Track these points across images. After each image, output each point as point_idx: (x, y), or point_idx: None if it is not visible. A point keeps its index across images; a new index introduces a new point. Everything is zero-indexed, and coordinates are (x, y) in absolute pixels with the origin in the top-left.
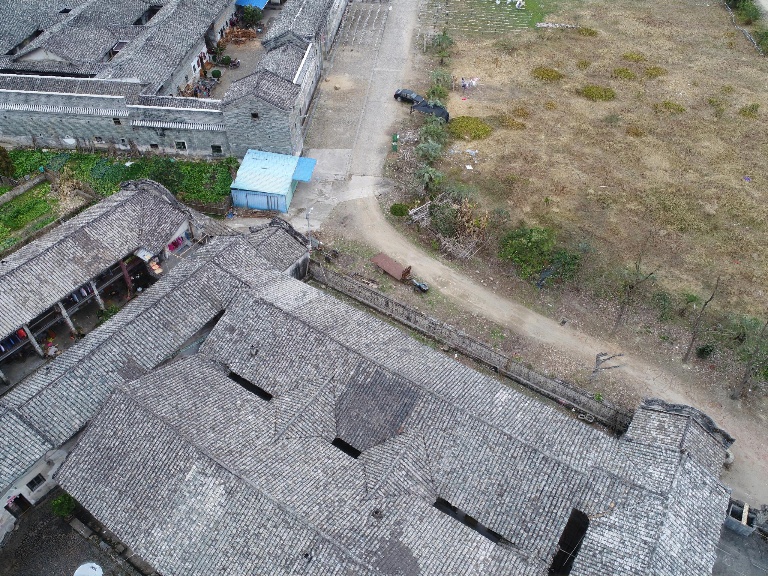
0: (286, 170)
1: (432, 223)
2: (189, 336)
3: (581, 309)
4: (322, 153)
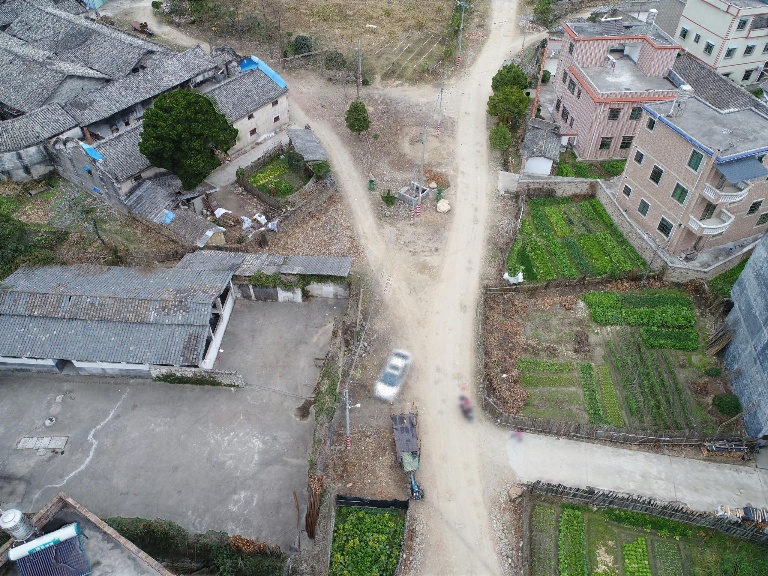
0: None
1: (170, 8)
2: (1, 25)
3: (234, 43)
4: None
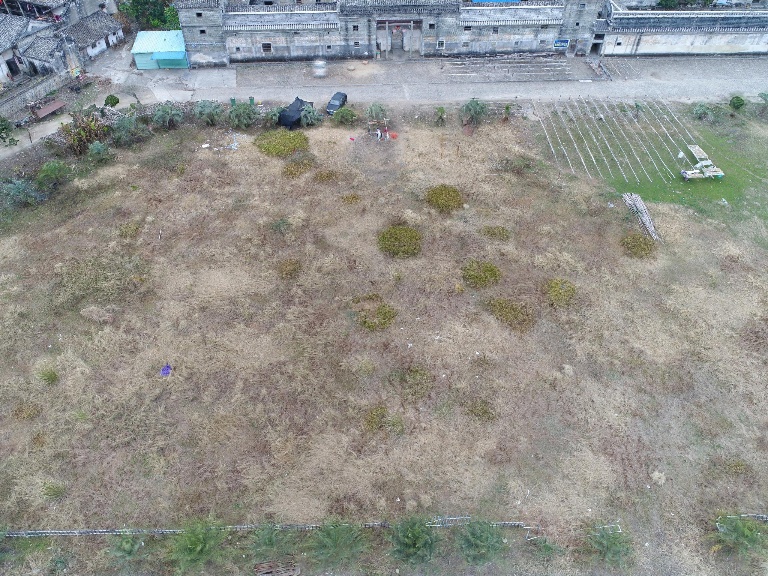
0: (164, 48)
1: None
2: None
3: None
4: (228, 75)
